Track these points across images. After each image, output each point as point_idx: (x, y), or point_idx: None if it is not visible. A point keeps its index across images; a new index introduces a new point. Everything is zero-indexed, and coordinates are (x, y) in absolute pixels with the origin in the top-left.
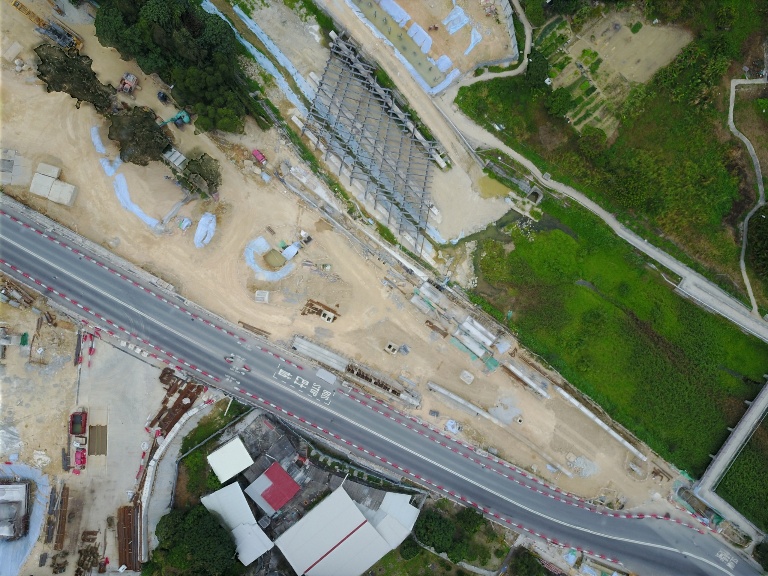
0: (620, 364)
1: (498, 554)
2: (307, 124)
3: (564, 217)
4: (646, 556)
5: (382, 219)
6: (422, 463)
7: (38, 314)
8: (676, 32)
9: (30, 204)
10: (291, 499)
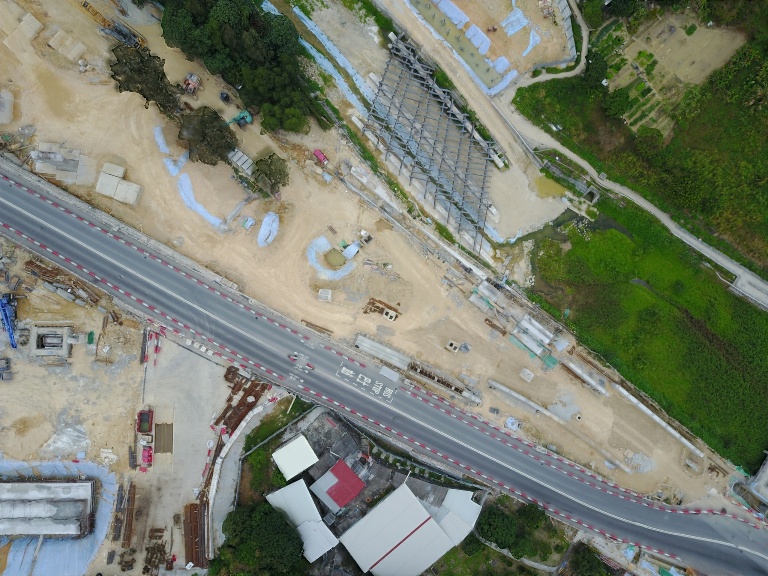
0: (675, 361)
1: (558, 550)
2: (368, 124)
3: (620, 216)
4: (703, 551)
5: (441, 218)
6: (483, 460)
7: (104, 313)
8: (730, 34)
9: (95, 203)
10: (355, 496)
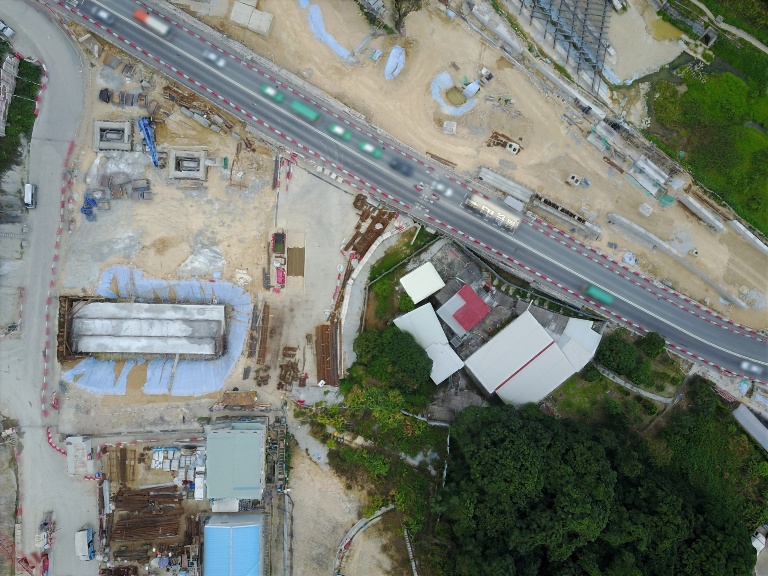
0: None
1: (675, 380)
2: None
3: (736, 59)
4: None
5: (559, 60)
6: (601, 293)
7: (237, 139)
8: None
9: (227, 34)
10: (479, 322)
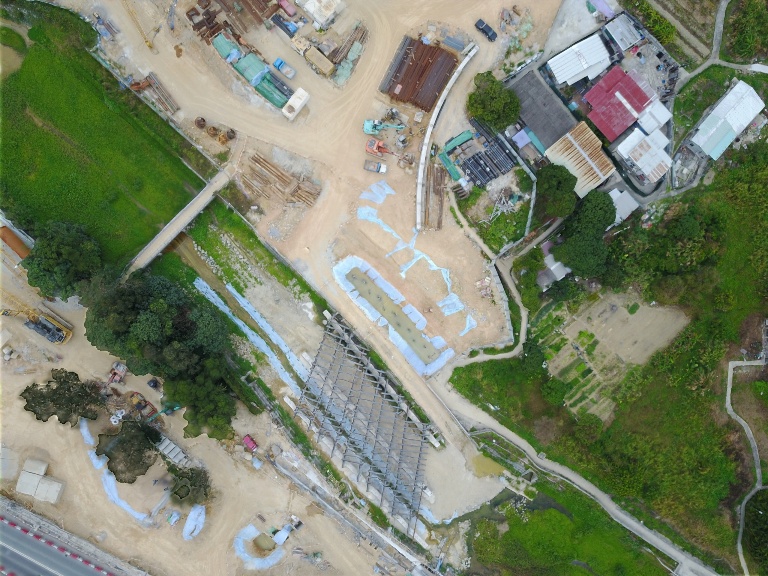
0: None
1: None
2: (299, 408)
3: (559, 498)
4: None
5: (374, 499)
6: None
7: None
8: (673, 313)
9: (16, 498)
10: None
